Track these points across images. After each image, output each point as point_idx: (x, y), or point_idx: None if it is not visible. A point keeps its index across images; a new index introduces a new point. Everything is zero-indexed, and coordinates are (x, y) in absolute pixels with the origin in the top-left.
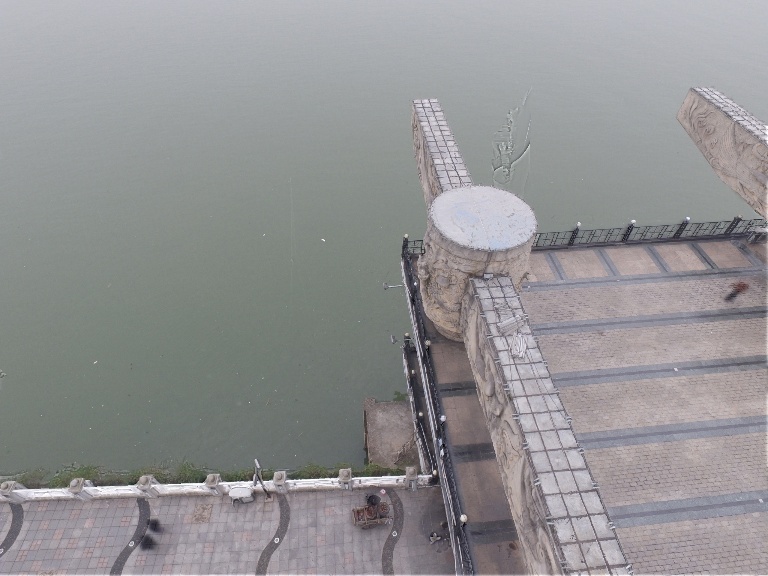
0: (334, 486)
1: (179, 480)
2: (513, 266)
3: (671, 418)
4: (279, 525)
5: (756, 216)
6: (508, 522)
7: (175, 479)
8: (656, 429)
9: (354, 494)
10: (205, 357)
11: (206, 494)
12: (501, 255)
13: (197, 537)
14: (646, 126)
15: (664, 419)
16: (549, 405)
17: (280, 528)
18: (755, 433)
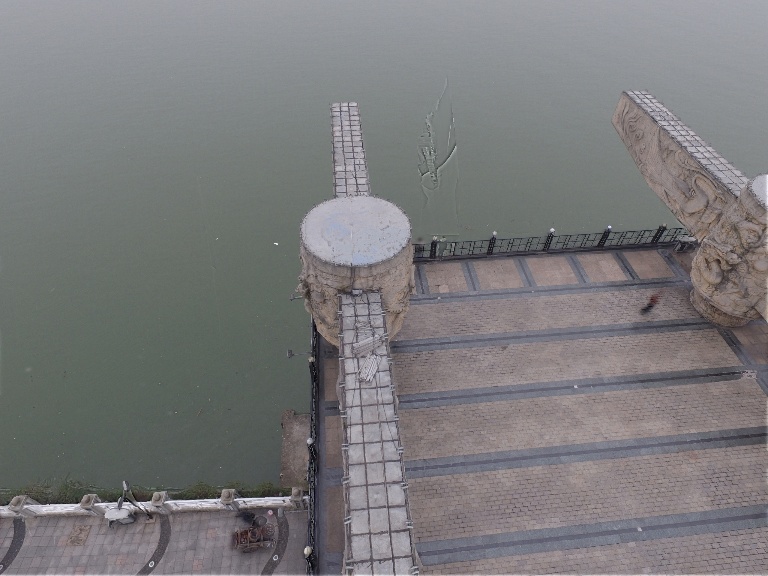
0: (219, 506)
1: (59, 500)
2: (384, 281)
3: (561, 439)
4: (157, 548)
5: (681, 225)
6: None
7: (55, 498)
8: (543, 451)
9: (240, 515)
10: (117, 368)
11: (86, 514)
12: (365, 271)
13: (69, 560)
14: (575, 131)
15: (553, 440)
16: (384, 434)
17: (157, 551)
18: (646, 456)
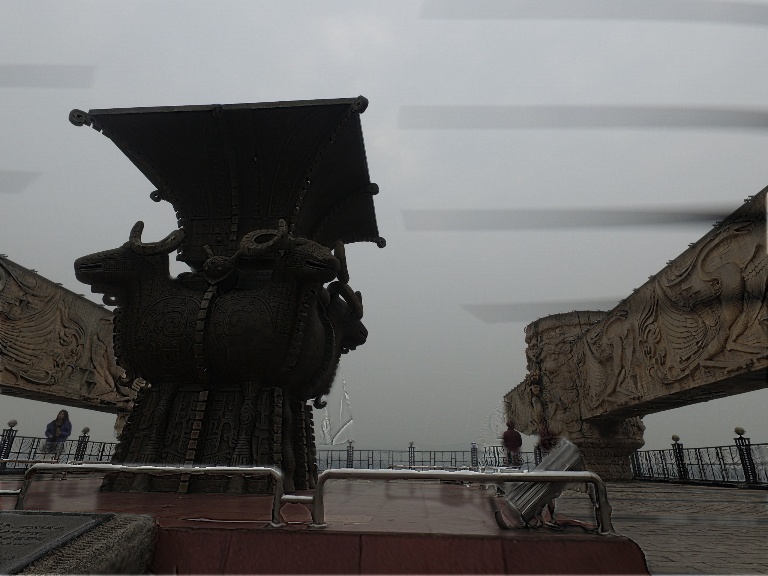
0: None
1: None
2: None
3: None
4: None
5: None
6: None
7: None
8: None
9: None
10: None
11: None
12: None
13: None
14: (461, 415)
15: None
16: None
17: None
18: None
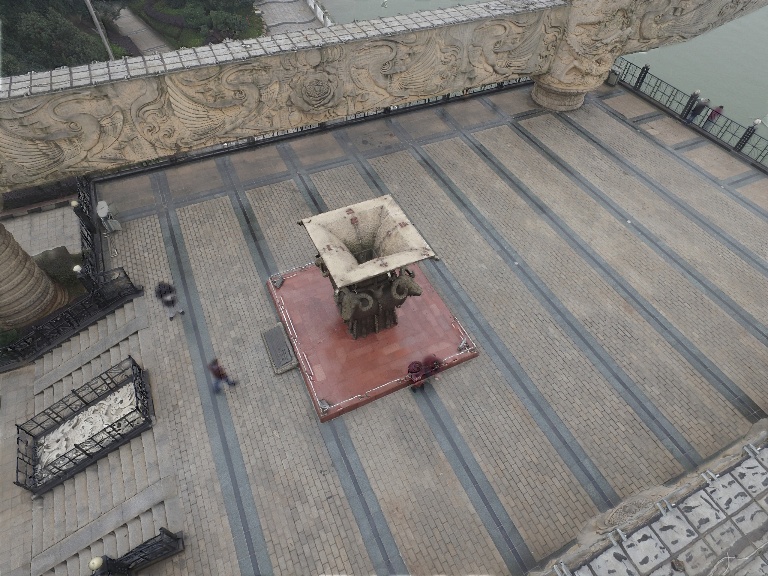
0: None
1: None
2: None
3: (562, 213)
4: None
5: None
6: (406, 133)
7: None
8: (541, 203)
9: None
10: None
11: None
12: None
13: None
14: None
15: (557, 209)
16: (458, 17)
17: None
18: (596, 271)
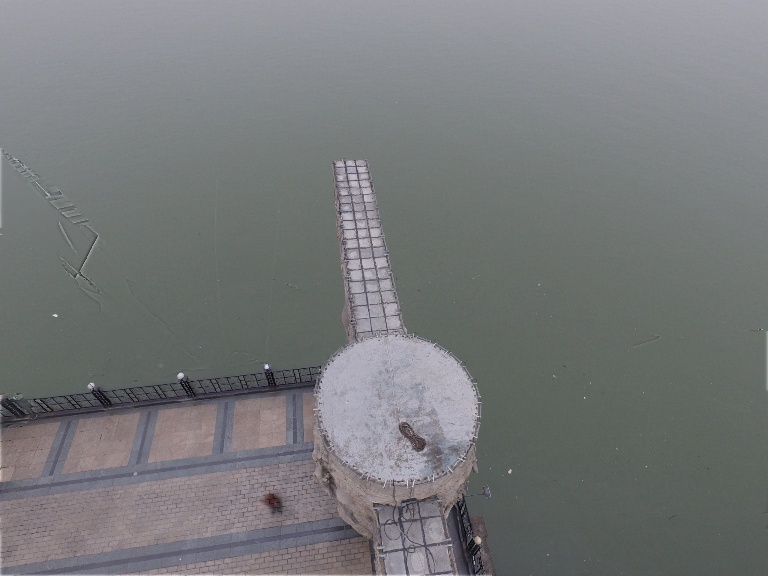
0: None
1: None
2: None
3: None
4: None
5: None
6: None
7: None
8: None
9: None
10: None
11: None
12: None
13: None
14: (264, 217)
15: None
16: None
17: None
18: None
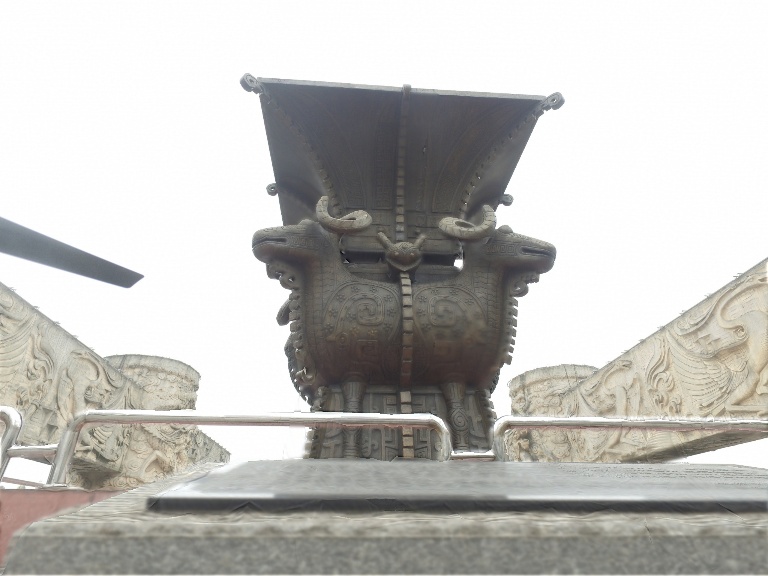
0: None
1: None
2: (150, 383)
3: None
4: None
5: None
6: None
7: None
8: None
9: None
10: None
11: None
12: (135, 360)
13: None
14: None
15: None
16: None
17: None
18: None
